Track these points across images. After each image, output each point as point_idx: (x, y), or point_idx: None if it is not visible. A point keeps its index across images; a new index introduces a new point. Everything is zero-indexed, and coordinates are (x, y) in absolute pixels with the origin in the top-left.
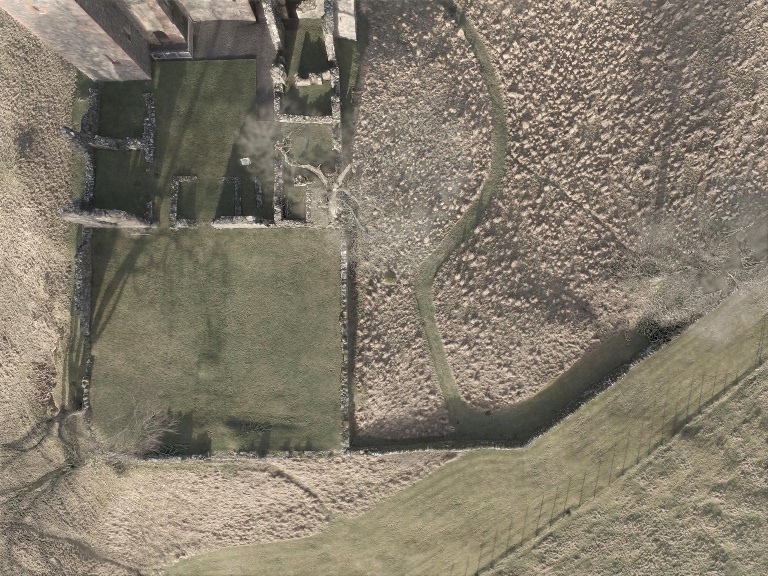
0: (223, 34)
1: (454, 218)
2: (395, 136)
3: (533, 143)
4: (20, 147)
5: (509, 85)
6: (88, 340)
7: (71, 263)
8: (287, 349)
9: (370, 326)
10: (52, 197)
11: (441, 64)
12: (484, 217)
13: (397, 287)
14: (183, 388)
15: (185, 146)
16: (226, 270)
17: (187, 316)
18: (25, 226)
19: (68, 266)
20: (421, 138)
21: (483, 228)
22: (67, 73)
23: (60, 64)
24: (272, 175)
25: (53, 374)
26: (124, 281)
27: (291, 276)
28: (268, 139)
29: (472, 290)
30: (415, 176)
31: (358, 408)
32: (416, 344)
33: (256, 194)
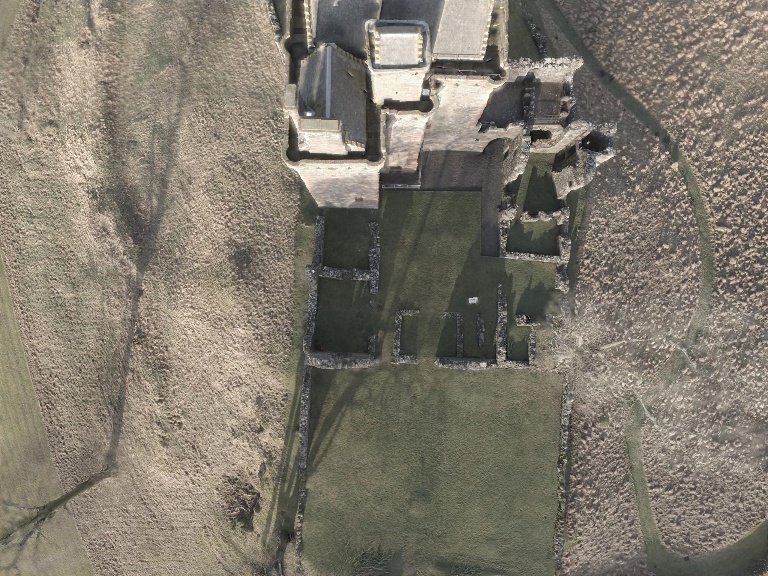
0: (450, 165)
1: (663, 357)
2: (613, 274)
3: (739, 279)
4: (237, 267)
5: (717, 218)
6: (304, 473)
7: (288, 391)
8: (501, 492)
9: (583, 471)
10: (271, 322)
11: (657, 198)
12: (691, 356)
13: (609, 430)
14: (393, 525)
15: (409, 278)
16: (442, 407)
17: (401, 452)
18: (236, 346)
19: (285, 394)
20: (635, 275)
21: (690, 368)
22: (289, 194)
23: (281, 184)
24: (495, 313)
25: (244, 489)
26: (342, 414)
27: (509, 417)
28: (492, 275)
29: (679, 433)
30: (629, 314)
31: (566, 553)
32: (624, 488)
33: (478, 332)
